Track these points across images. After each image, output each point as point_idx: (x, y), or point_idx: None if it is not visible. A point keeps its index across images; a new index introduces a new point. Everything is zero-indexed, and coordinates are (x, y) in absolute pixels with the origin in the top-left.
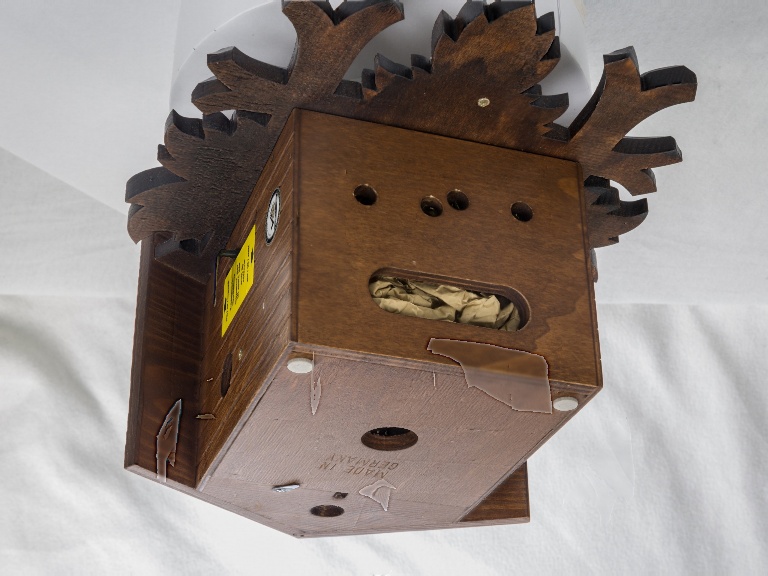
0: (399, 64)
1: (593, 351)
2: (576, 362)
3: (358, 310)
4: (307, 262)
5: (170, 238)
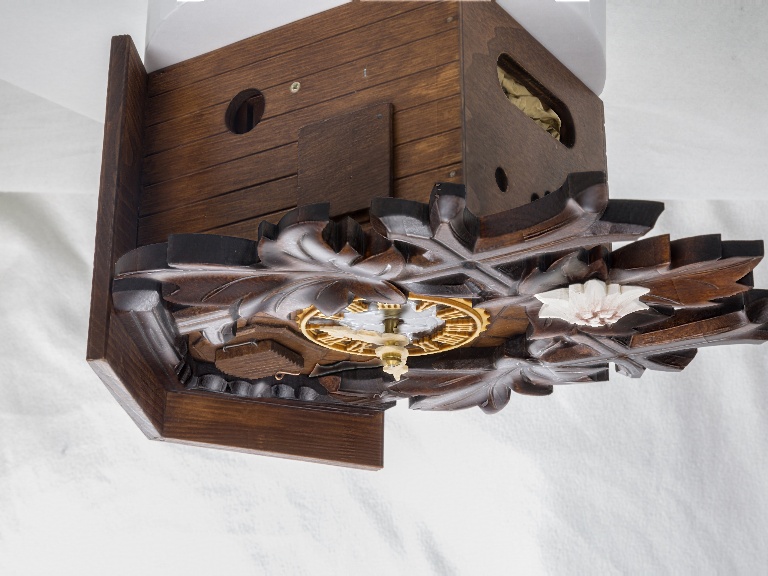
0: (656, 309)
1: (463, 6)
2: (473, 2)
3: (579, 113)
4: (602, 168)
5: (366, 426)
